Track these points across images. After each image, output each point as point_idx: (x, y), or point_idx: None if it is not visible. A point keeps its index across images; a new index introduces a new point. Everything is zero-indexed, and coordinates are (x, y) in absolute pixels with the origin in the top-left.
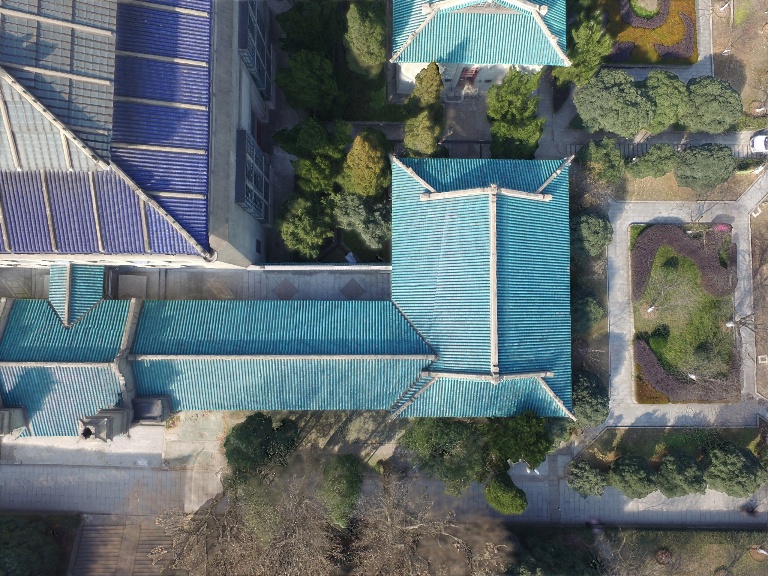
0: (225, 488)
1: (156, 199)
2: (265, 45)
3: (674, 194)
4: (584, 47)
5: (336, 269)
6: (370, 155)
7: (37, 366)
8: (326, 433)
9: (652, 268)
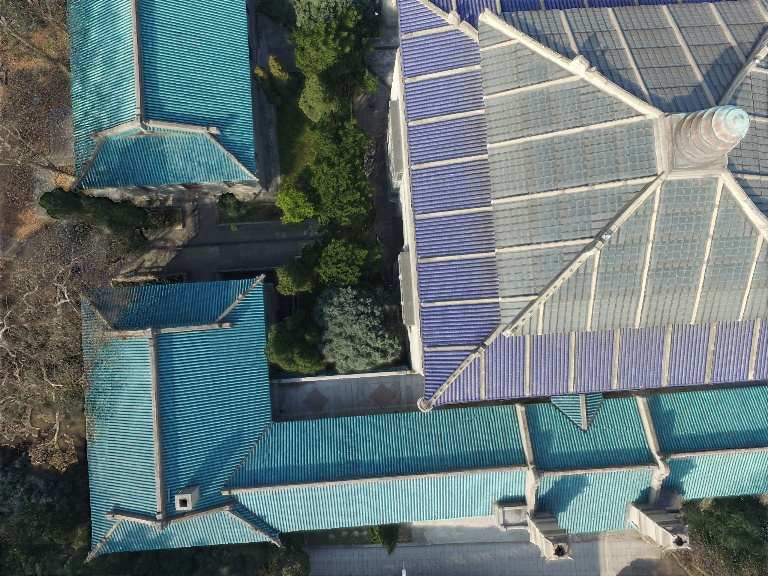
0: (733, 571)
1: None
2: None
3: None
4: None
5: None
6: None
7: None
8: None
9: None
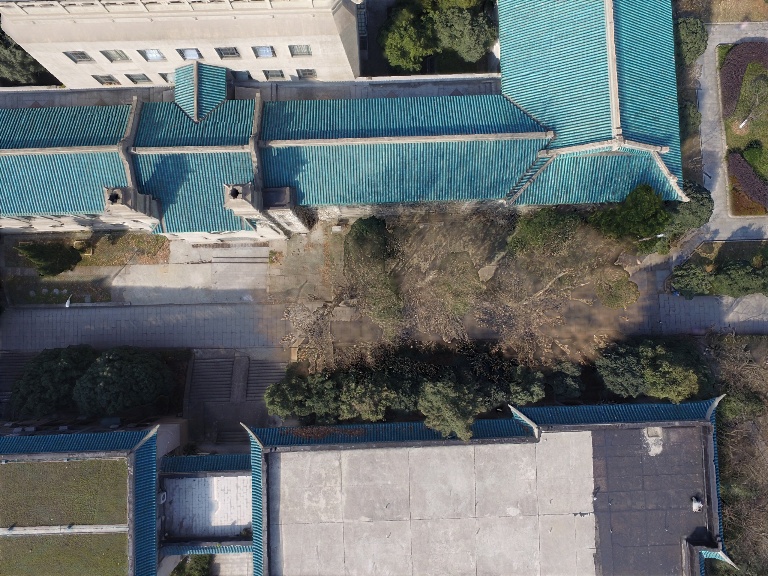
0: (350, 276)
1: None
2: None
3: (759, 15)
4: None
5: (441, 78)
6: None
7: (173, 153)
8: (427, 258)
9: (741, 86)
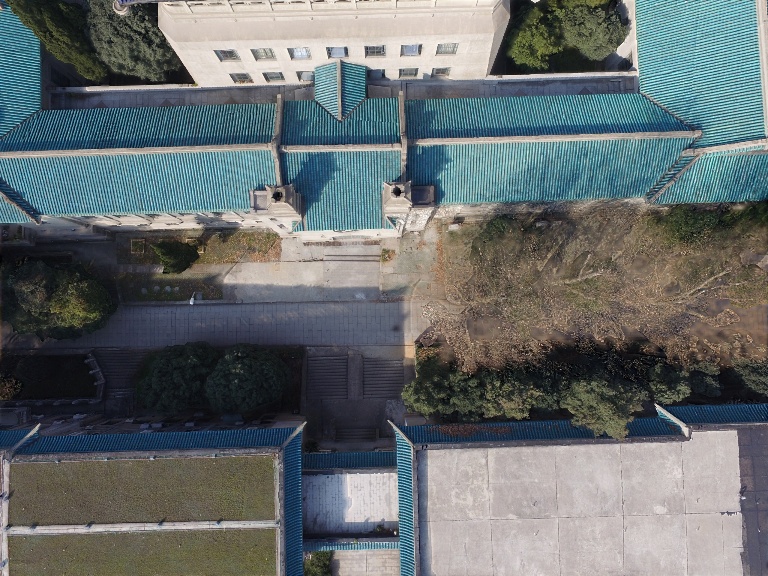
0: (491, 275)
1: None
2: None
3: None
4: None
5: (571, 77)
6: None
7: (321, 151)
8: (544, 256)
9: None
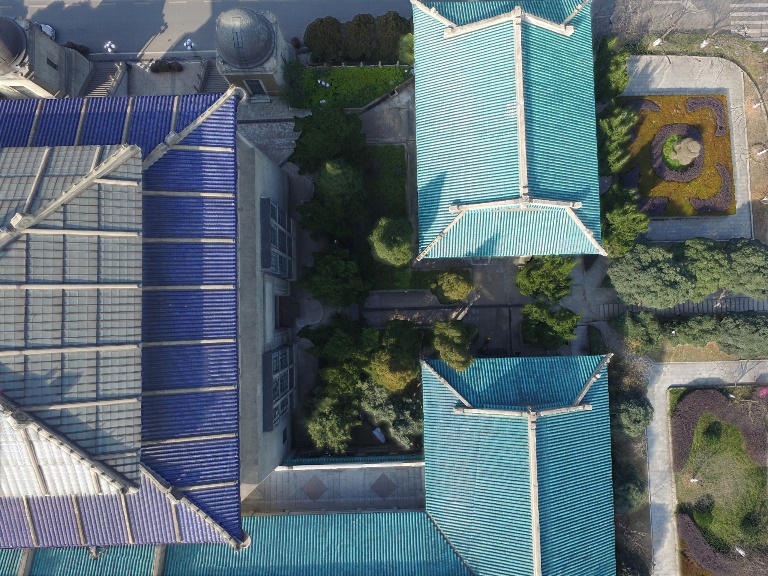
0: None
1: (187, 494)
2: (286, 231)
3: (714, 353)
4: (619, 227)
5: (366, 467)
6: (401, 376)
7: None
8: None
9: (694, 434)
